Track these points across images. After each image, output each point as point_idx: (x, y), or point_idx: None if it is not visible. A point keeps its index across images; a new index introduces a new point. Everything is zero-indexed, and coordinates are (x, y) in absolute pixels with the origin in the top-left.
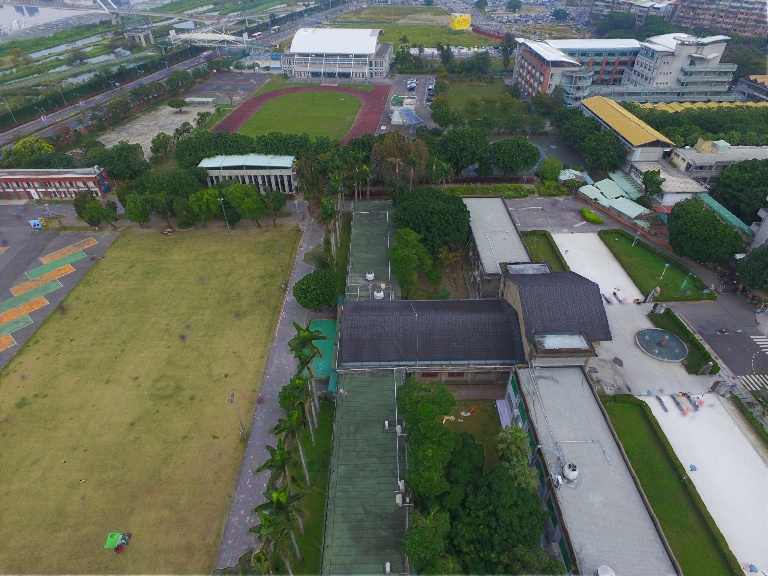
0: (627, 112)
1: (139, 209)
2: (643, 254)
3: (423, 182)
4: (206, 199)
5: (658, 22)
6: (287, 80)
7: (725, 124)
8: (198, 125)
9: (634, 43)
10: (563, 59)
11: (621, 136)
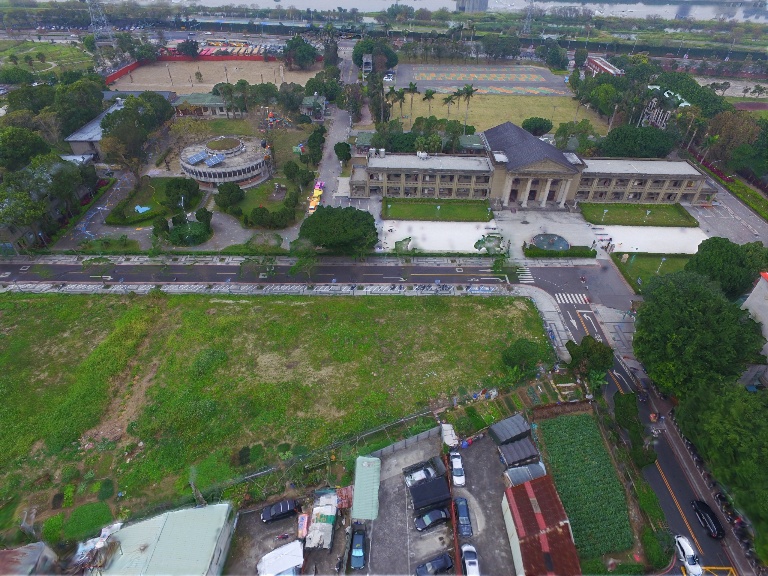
0: None
1: None
2: None
3: None
4: None
5: None
6: None
7: None
8: (745, 93)
9: None
10: None
11: None
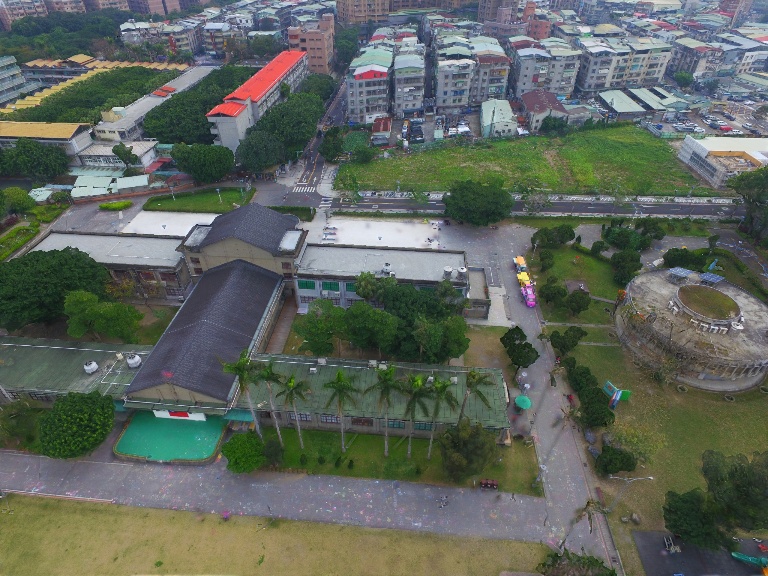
0: (2, 121)
1: None
2: (189, 199)
3: None
4: None
5: None
6: None
7: (89, 99)
8: None
9: None
10: None
11: (40, 139)
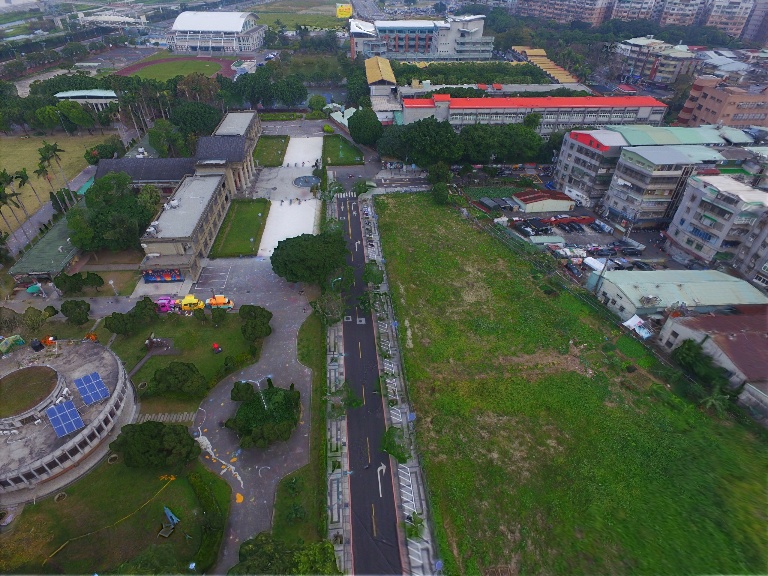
0: (387, 66)
1: (1, 119)
2: (343, 146)
3: (222, 110)
4: (48, 112)
5: (497, 12)
6: (171, 53)
7: None
8: None
9: (442, 23)
10: (362, 31)
11: None
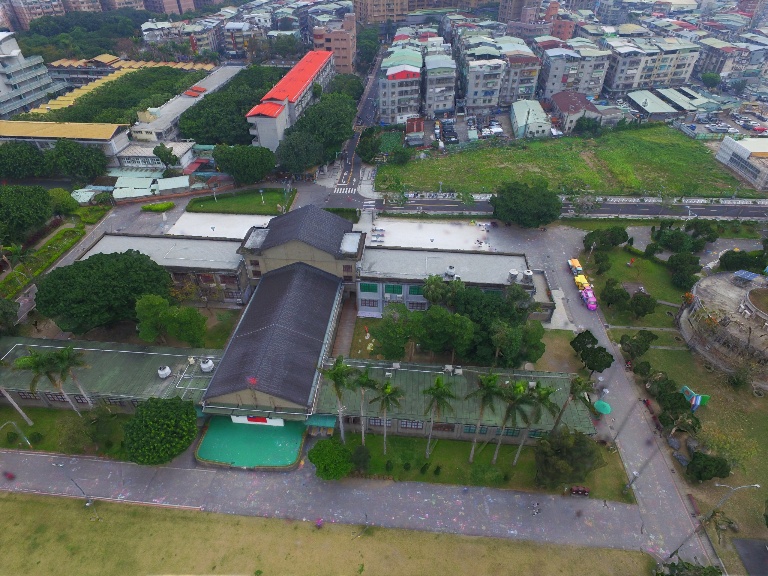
0: None
1: None
2: (230, 201)
3: None
4: None
5: None
6: None
7: (121, 99)
8: None
9: None
10: None
11: (79, 140)
